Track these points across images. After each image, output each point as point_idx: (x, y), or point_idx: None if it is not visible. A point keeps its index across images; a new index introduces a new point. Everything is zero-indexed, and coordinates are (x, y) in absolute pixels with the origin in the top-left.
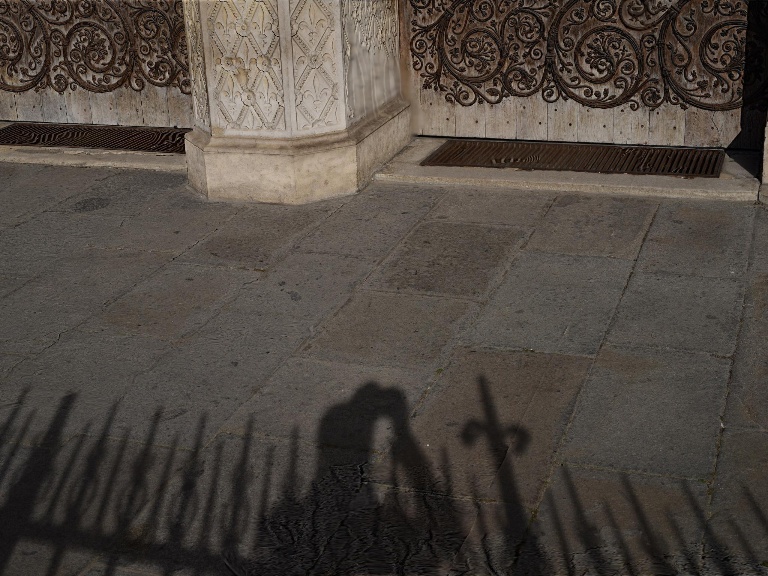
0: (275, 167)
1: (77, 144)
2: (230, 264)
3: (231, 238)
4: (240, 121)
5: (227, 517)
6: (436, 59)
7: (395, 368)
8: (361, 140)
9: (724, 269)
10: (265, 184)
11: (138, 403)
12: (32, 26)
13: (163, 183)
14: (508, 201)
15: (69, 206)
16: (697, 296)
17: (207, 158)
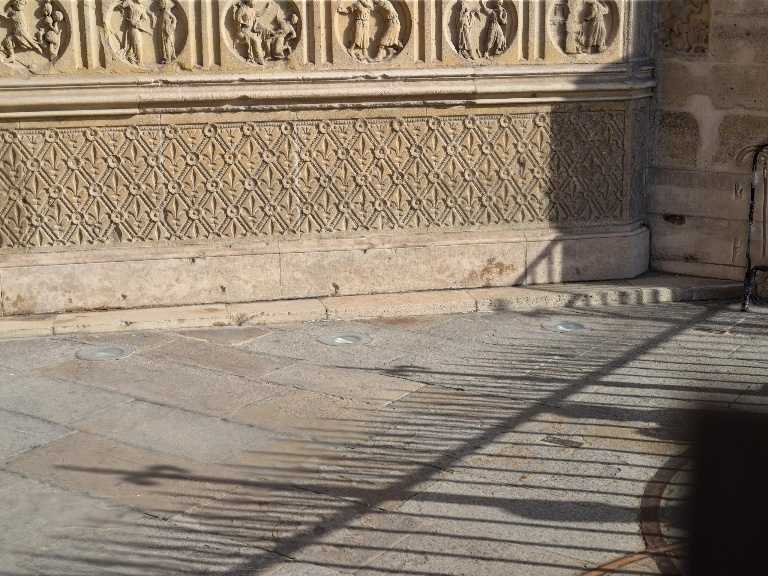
0: None
1: None
2: None
3: None
4: None
5: (164, 571)
6: None
7: None
8: None
9: (2, 375)
10: None
11: None
12: None
13: None
14: None
15: None
16: (33, 389)
17: None
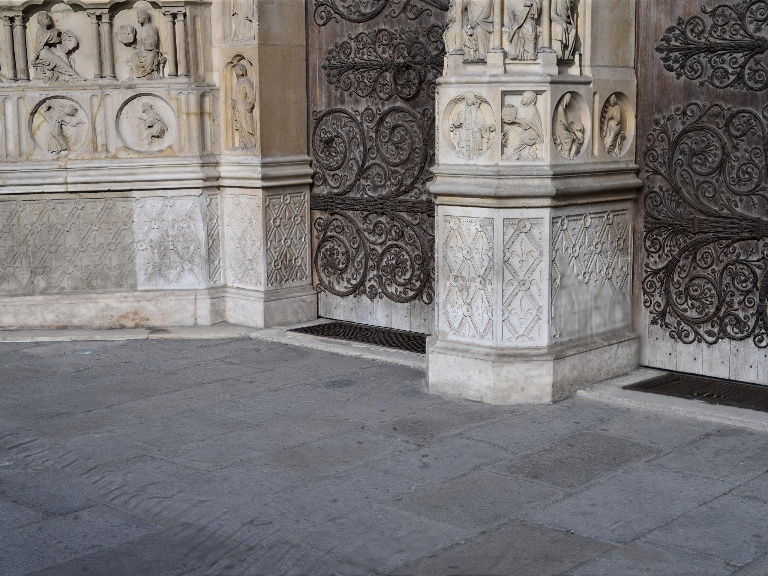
0: (480, 370)
1: (366, 340)
2: (399, 437)
3: (418, 420)
4: (460, 329)
5: None
6: (663, 299)
7: (450, 524)
8: (562, 357)
9: None
10: (471, 384)
11: (245, 512)
12: (358, 244)
13: (407, 376)
14: (676, 426)
15: (322, 382)
16: (763, 519)
17: (431, 356)
